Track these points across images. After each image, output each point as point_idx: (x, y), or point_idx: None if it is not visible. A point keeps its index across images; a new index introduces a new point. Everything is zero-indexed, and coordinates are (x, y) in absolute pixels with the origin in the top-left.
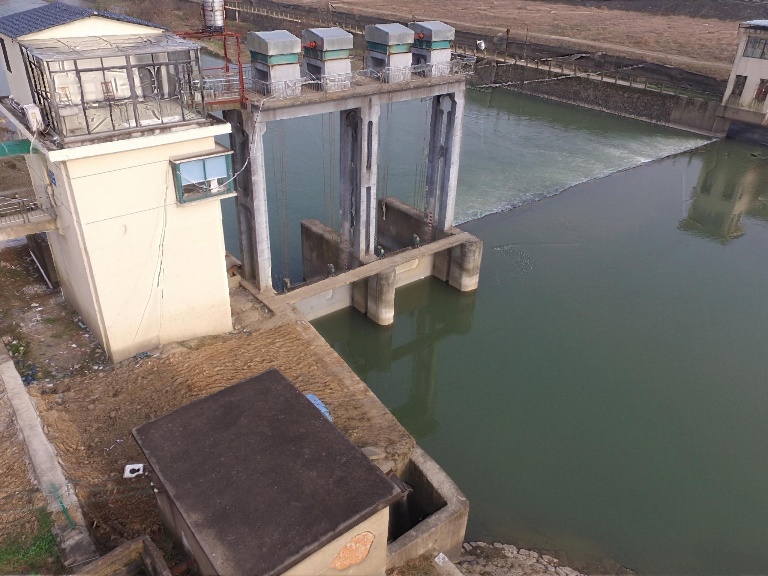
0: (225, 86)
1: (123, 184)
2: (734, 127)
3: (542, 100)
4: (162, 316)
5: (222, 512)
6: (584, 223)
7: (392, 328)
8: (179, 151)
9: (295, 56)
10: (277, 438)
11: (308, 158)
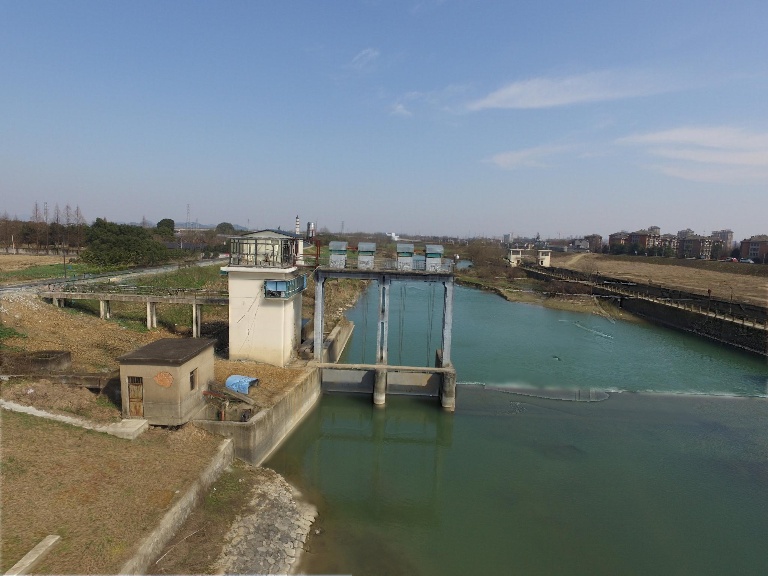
0: (310, 260)
1: (246, 285)
2: None
3: (736, 349)
4: (252, 346)
5: (143, 350)
6: (608, 409)
7: (382, 408)
8: (269, 277)
9: (343, 251)
10: None
11: (469, 342)
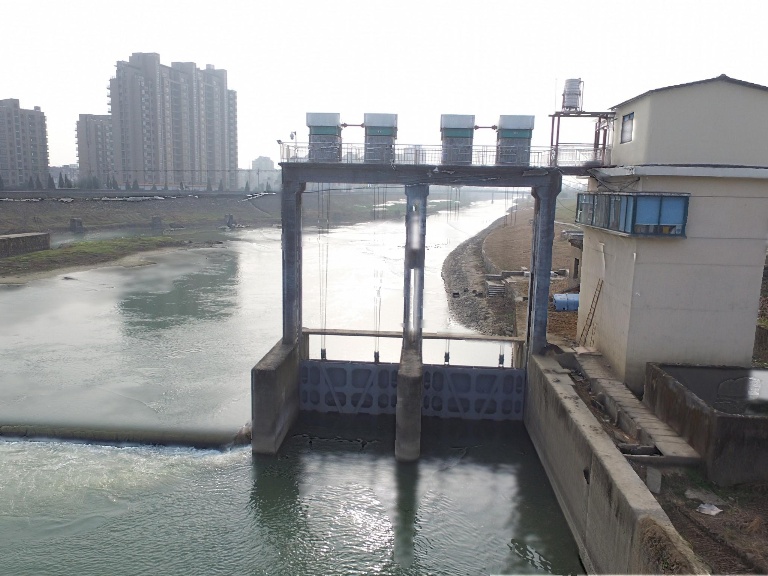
0: None
1: None
2: None
3: None
4: None
5: None
6: (11, 392)
7: None
8: None
9: None
10: None
11: None
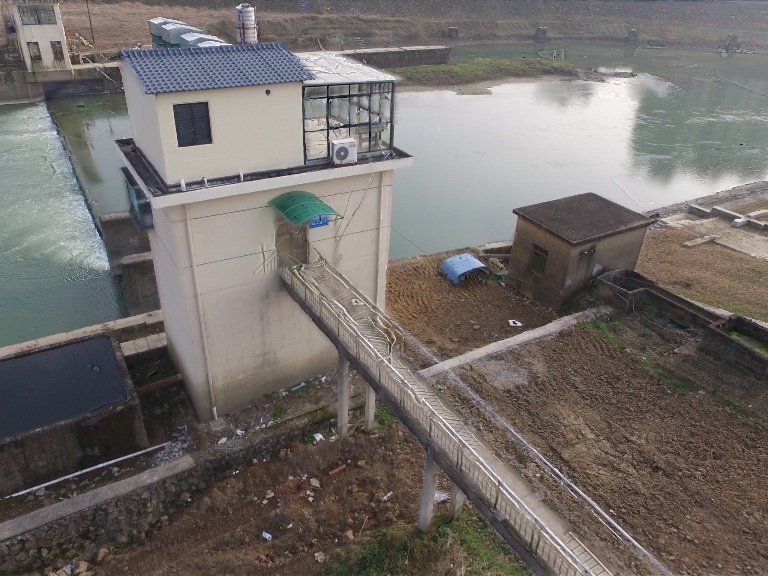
0: None
1: None
2: (48, 88)
3: None
4: None
5: None
6: None
7: None
8: None
9: None
10: (570, 210)
11: None
